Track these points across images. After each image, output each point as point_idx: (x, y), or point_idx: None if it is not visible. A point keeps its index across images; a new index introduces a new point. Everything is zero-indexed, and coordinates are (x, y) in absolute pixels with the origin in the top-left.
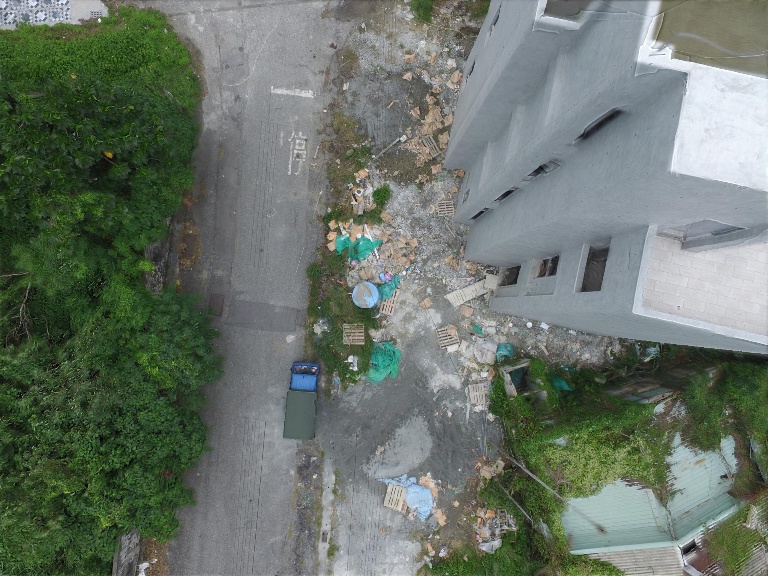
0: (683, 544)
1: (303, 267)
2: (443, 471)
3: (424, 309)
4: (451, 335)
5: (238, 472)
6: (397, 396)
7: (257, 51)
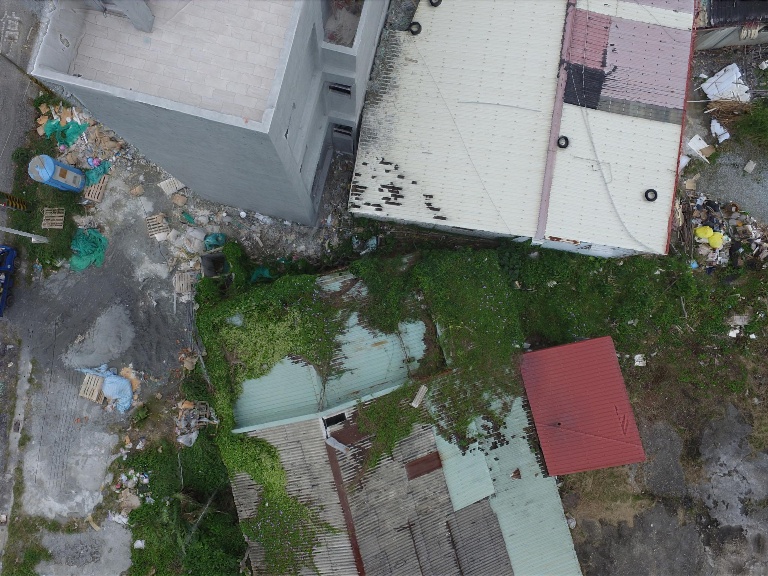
0: (328, 416)
1: (9, 150)
2: (146, 362)
3: (136, 197)
4: (160, 223)
5: None
6: (102, 285)
7: None
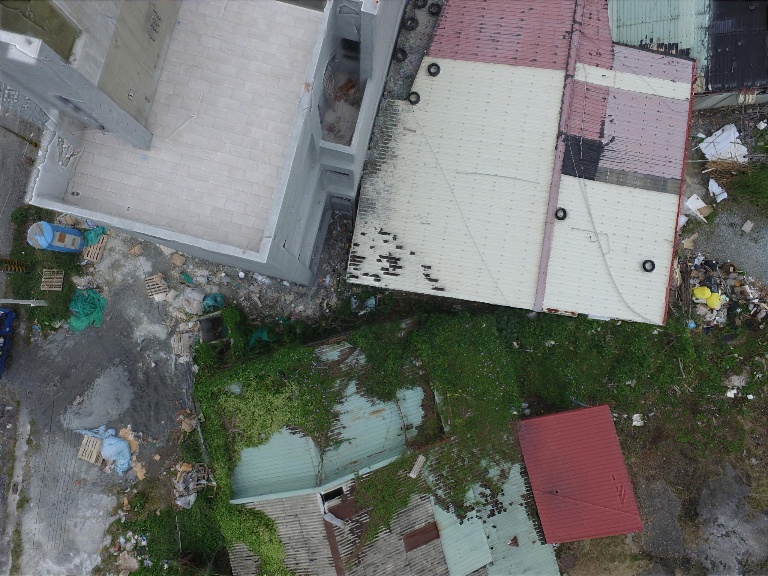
0: (326, 491)
1: (8, 211)
2: (145, 423)
3: (134, 257)
4: None
5: None
6: (100, 345)
7: None
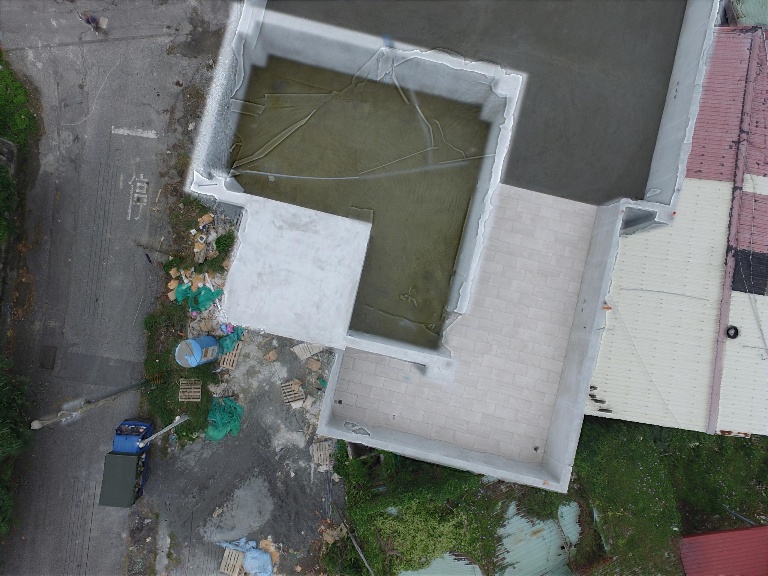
0: None
1: (141, 318)
2: (285, 534)
3: (269, 362)
4: (295, 390)
5: (65, 536)
6: (238, 454)
7: (97, 89)
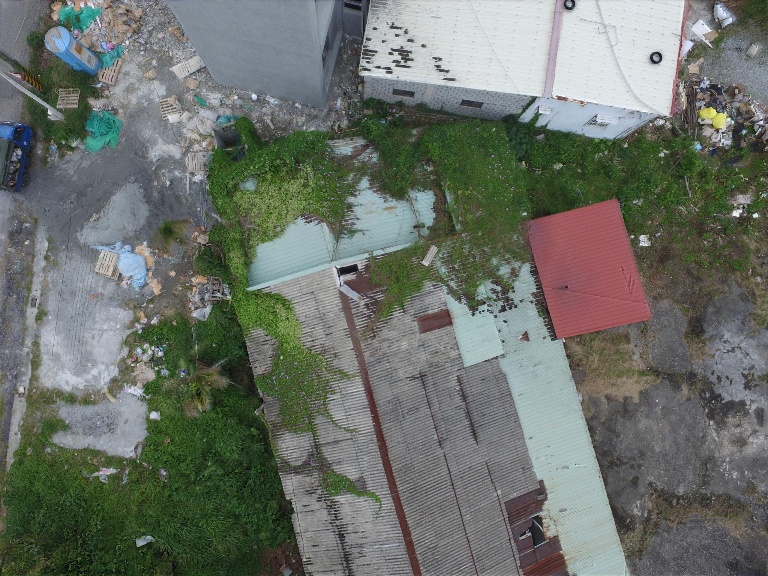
0: (341, 266)
1: (24, 35)
2: (160, 241)
3: (148, 80)
4: (173, 105)
5: None
6: (116, 165)
7: None
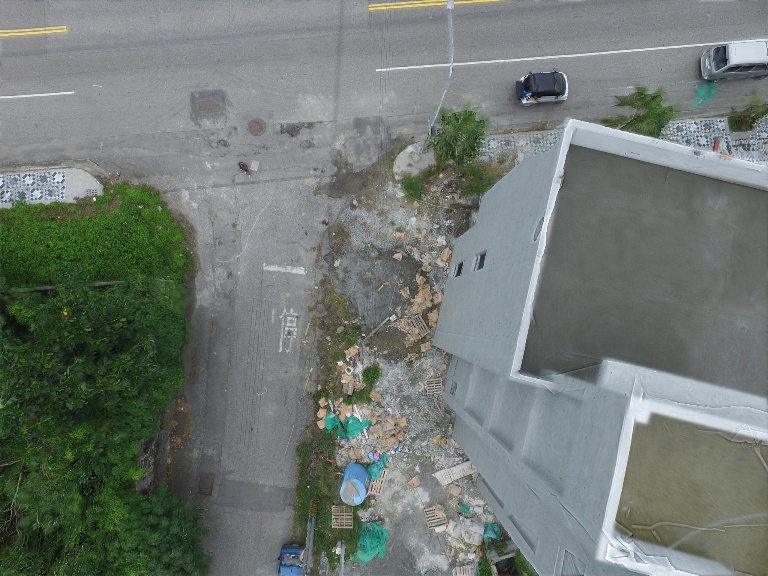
0: None
1: (293, 446)
2: None
3: (412, 488)
4: (439, 516)
5: None
6: None
7: (250, 228)
